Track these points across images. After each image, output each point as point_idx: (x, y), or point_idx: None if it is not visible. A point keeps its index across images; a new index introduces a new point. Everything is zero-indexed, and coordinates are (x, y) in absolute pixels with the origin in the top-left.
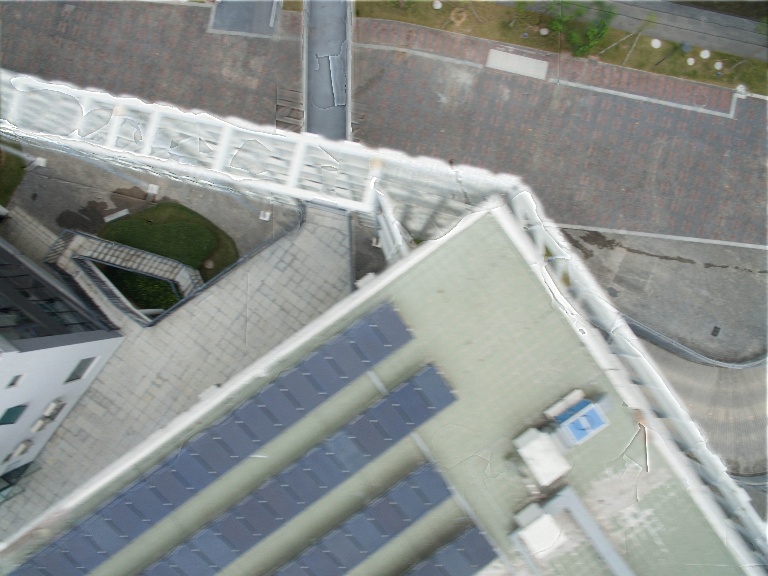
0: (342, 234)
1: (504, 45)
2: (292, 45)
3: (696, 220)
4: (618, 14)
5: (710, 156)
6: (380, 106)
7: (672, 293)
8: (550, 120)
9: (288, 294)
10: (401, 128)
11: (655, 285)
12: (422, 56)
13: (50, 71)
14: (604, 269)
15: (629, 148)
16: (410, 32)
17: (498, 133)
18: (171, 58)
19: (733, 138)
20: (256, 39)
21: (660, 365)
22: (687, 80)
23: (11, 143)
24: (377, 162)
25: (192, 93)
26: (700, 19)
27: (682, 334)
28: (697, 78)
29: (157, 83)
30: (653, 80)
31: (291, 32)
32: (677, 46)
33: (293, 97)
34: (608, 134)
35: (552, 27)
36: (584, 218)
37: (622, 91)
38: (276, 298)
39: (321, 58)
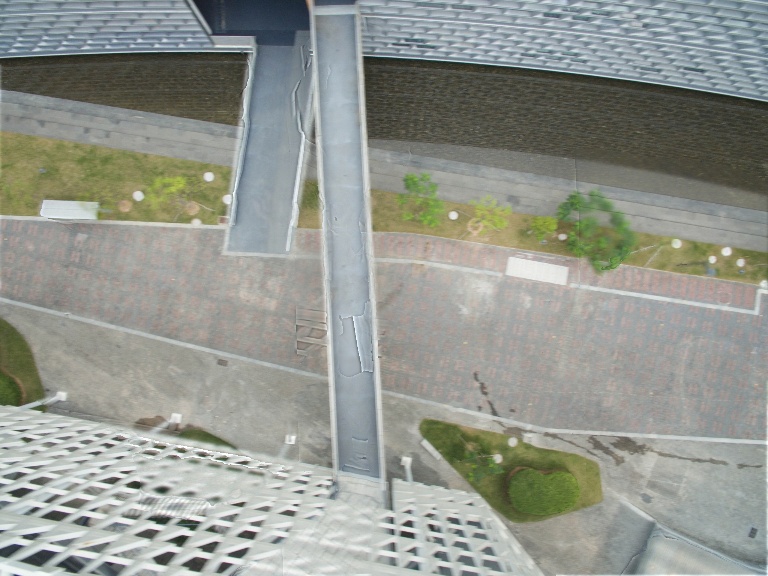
0: (376, 502)
1: (523, 252)
2: (309, 263)
3: (727, 420)
4: (636, 215)
5: (737, 354)
6: (401, 321)
7: (706, 496)
8: (573, 326)
9: (324, 566)
10: (423, 342)
11: (689, 489)
12: (441, 267)
13: (66, 302)
14: (636, 475)
15: (655, 350)
16: (427, 244)
17: (521, 342)
18: (187, 283)
19: (759, 335)
20: (272, 259)
21: (697, 562)
22: (710, 278)
23: (30, 378)
24: (401, 378)
25: (210, 317)
26: (719, 215)
27: (719, 538)
28: (720, 276)
29: (174, 309)
30: (675, 280)
31: (307, 250)
32: (698, 245)
33: (312, 316)
34: (633, 337)
35: (571, 232)
36: (613, 424)
37: (645, 293)
38: (312, 571)
39: (345, 320)
